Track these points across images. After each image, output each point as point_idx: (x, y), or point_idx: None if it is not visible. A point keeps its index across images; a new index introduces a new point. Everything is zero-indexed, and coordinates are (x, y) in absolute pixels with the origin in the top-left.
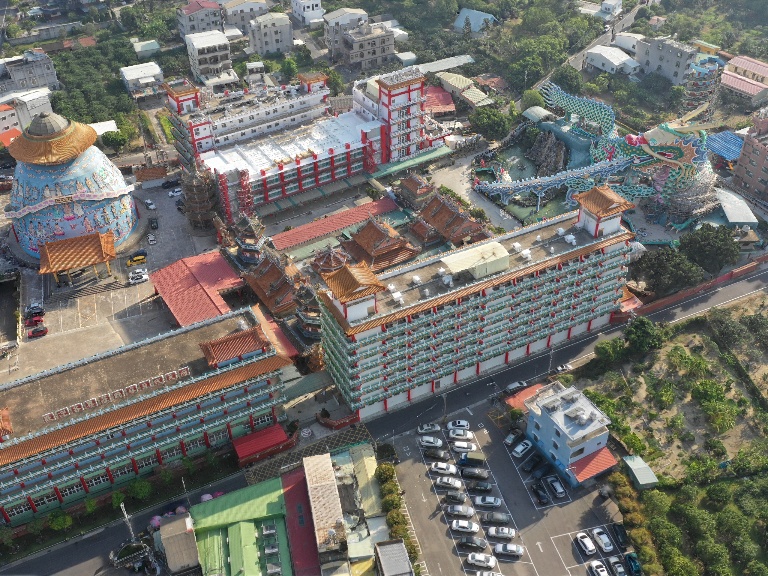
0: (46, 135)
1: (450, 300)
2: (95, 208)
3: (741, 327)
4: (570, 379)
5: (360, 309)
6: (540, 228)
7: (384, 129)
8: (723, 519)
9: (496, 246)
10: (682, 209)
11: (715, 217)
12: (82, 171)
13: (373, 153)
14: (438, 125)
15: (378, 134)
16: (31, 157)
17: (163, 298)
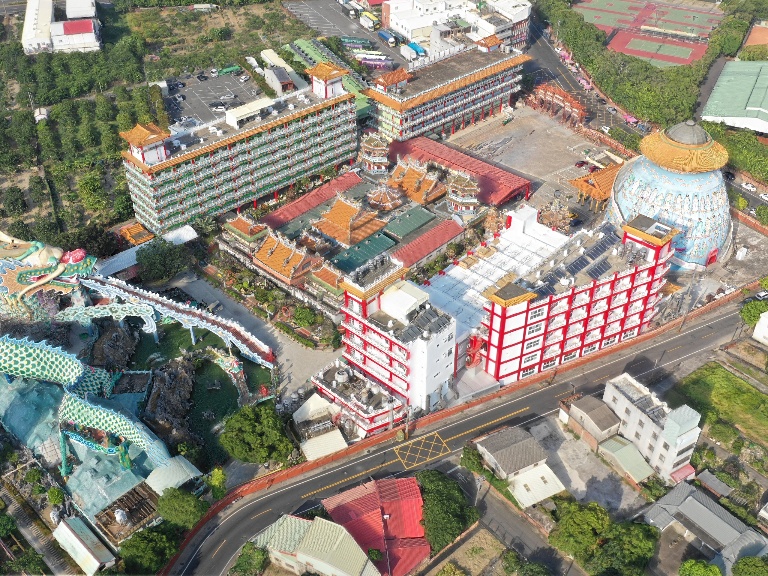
0: None
1: None
2: None
3: (41, 223)
4: None
5: None
6: None
7: None
8: (116, 134)
9: (236, 111)
10: None
11: None
12: None
13: None
14: None
15: None
16: None
17: None
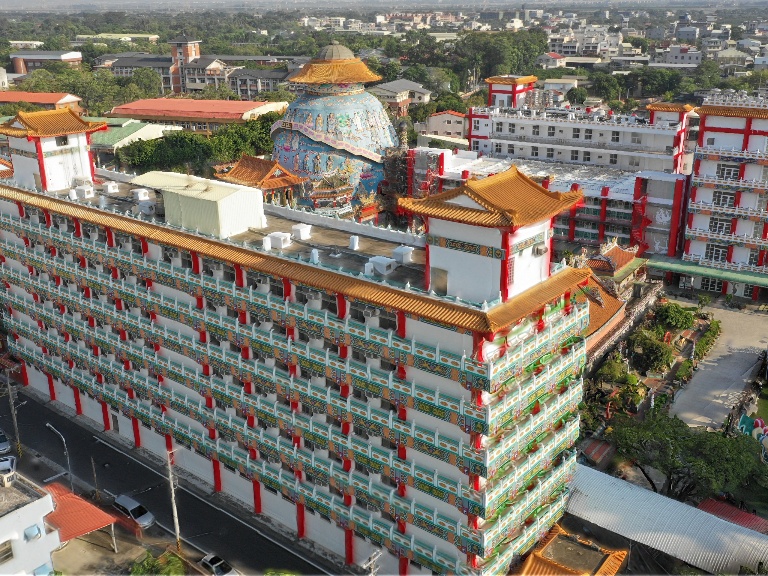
0: (316, 59)
1: (87, 219)
2: (311, 149)
3: None
4: (158, 573)
5: (27, 170)
6: (405, 243)
7: (679, 188)
8: None
9: None
10: None
11: None
12: (323, 107)
13: (653, 227)
14: None
15: (670, 195)
16: None
17: None
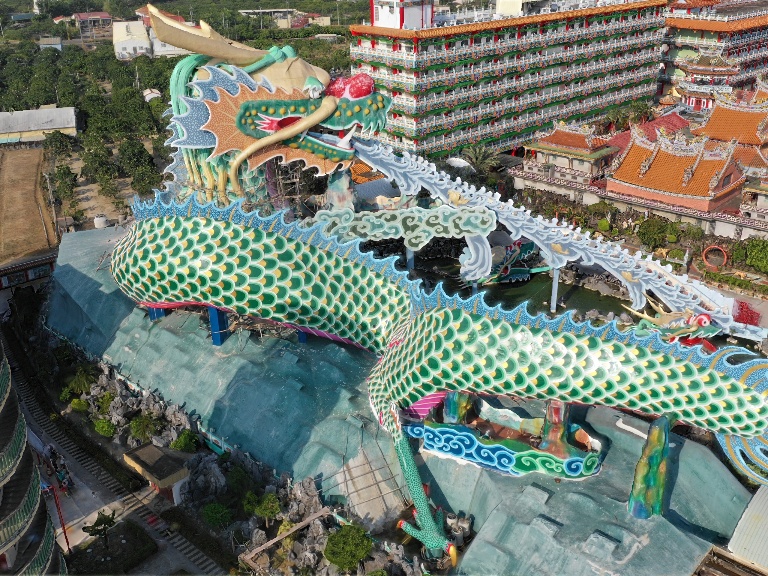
0: None
1: None
2: None
3: None
4: None
5: None
6: None
7: None
8: None
9: None
10: None
11: None
12: None
13: None
14: None
15: None
16: None
17: None
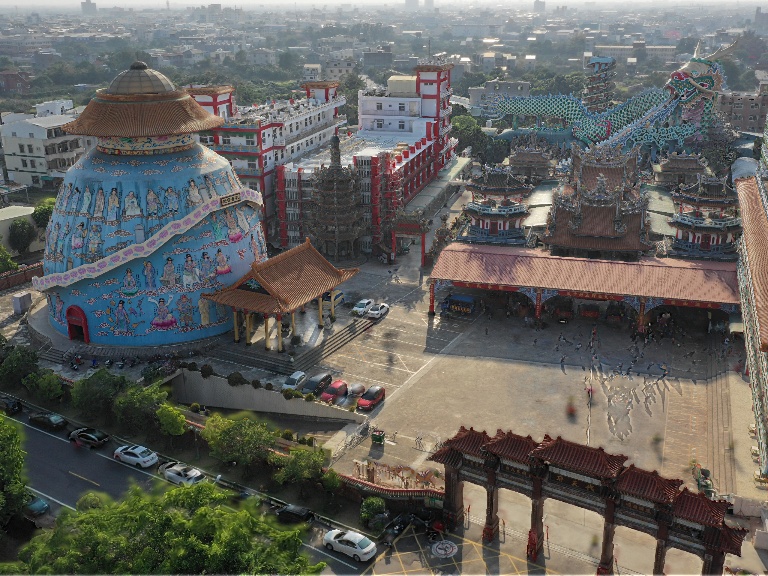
0: None
1: None
2: (255, 221)
3: None
4: None
5: None
6: None
7: (437, 124)
8: None
9: None
10: (722, 139)
11: (742, 141)
12: None
13: None
14: None
15: (432, 132)
16: (160, 128)
17: (502, 283)
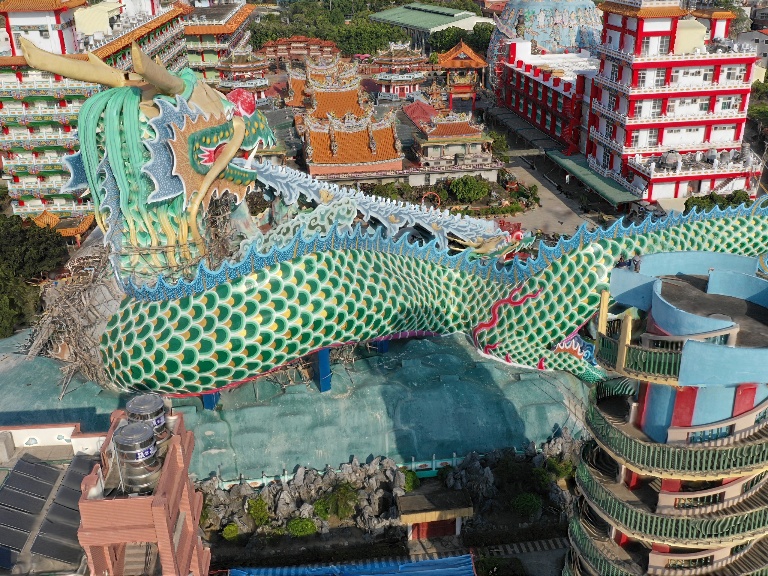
0: None
1: None
2: None
3: None
4: None
5: None
6: None
7: (594, 87)
8: None
9: None
10: None
11: None
12: None
13: (585, 126)
14: (695, 173)
15: None
16: None
17: None
